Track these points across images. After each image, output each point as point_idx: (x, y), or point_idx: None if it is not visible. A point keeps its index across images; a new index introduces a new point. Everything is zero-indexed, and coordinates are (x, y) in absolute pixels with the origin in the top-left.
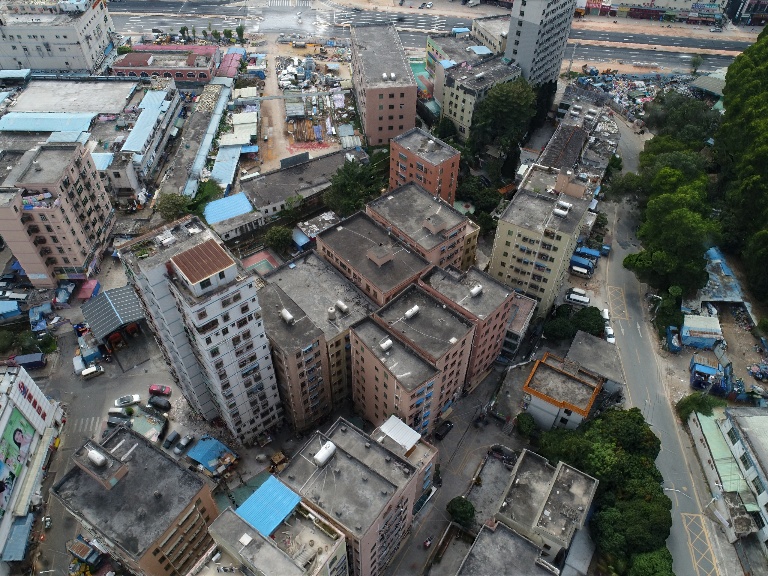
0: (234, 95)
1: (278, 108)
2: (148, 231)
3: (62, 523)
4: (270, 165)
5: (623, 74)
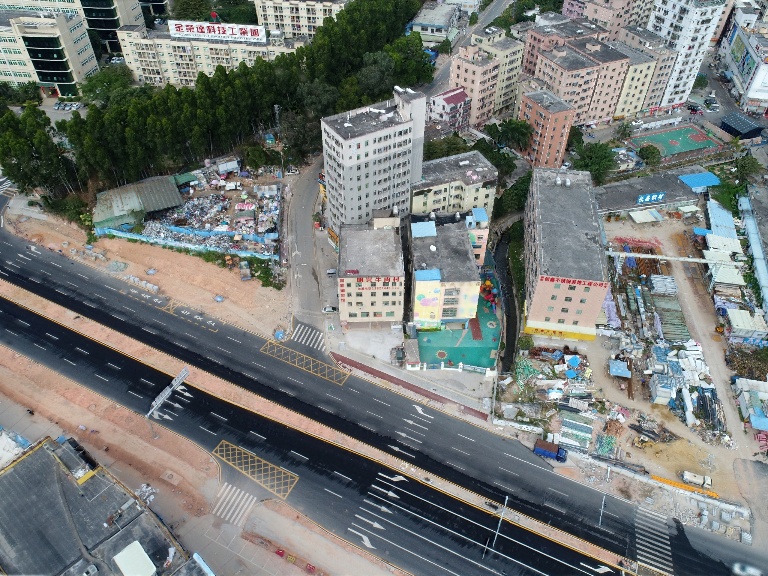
0: (761, 319)
1: (690, 307)
2: (758, 169)
3: (716, 86)
4: (676, 228)
5: (214, 255)
